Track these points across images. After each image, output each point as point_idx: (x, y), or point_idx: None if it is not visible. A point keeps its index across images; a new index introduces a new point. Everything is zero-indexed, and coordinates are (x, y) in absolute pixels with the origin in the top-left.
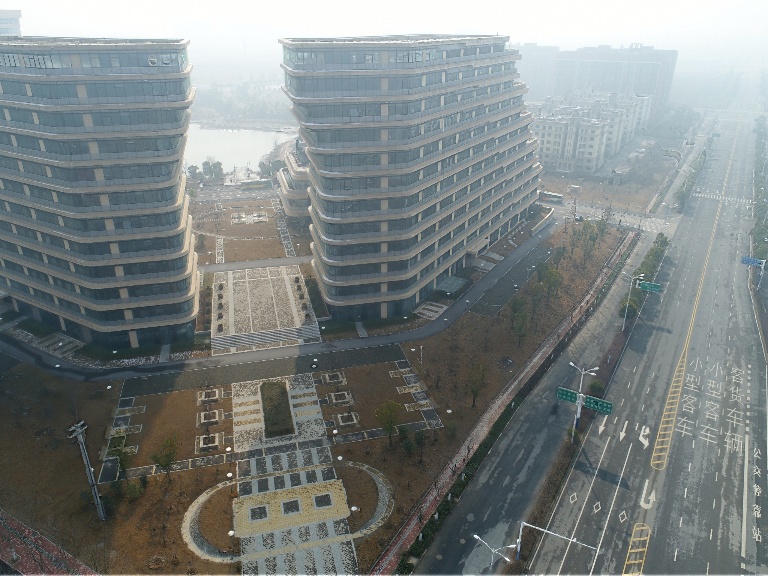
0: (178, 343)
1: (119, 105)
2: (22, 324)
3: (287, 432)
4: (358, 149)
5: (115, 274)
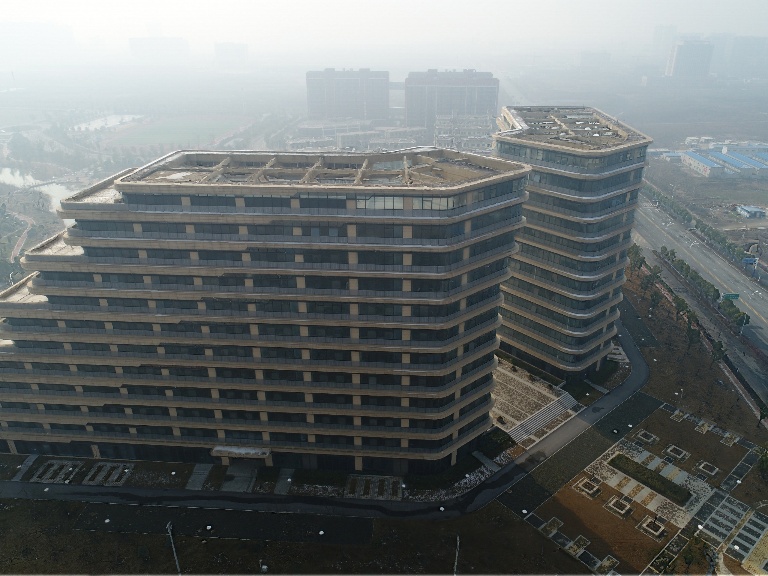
0: (485, 447)
1: (493, 233)
2: (301, 478)
3: (689, 496)
4: (614, 233)
5: (454, 398)
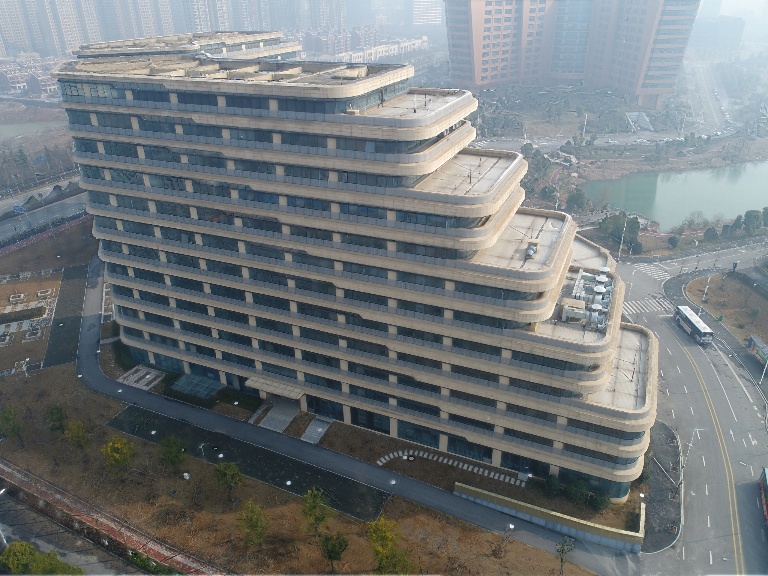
0: None
1: None
2: None
3: None
4: None
5: None
